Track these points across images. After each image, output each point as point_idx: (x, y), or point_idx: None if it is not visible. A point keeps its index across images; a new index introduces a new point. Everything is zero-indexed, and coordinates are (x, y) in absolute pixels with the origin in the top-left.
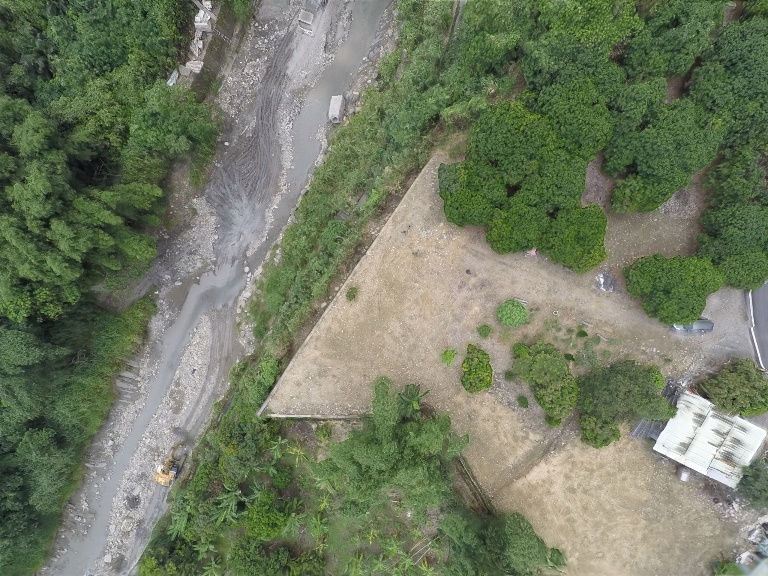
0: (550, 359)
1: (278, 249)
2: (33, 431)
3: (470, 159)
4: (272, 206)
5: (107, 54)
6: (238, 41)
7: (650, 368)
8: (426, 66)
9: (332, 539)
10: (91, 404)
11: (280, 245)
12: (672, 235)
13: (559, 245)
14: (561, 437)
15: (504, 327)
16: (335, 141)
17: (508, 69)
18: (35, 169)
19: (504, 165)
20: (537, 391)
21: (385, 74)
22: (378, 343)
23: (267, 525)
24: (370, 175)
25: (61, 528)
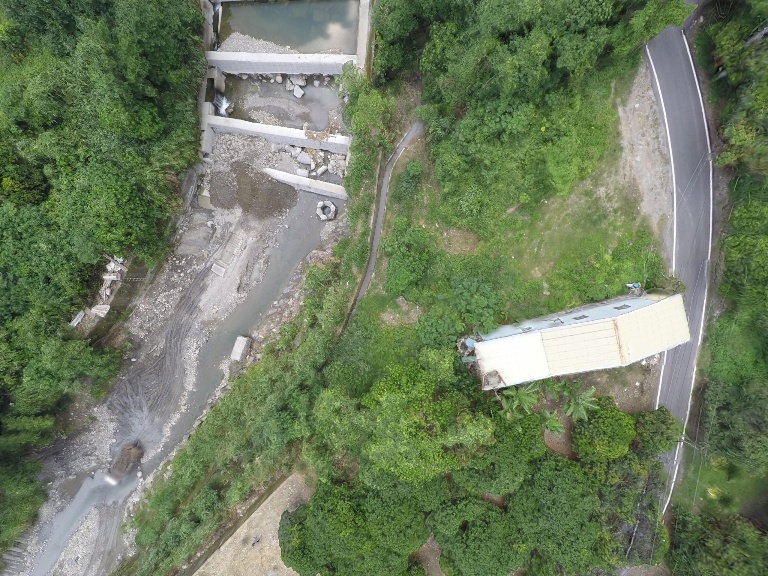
0: None
1: (169, 465)
2: None
3: None
4: (170, 423)
5: (8, 310)
6: (153, 275)
7: None
8: (311, 364)
9: None
10: None
11: (172, 461)
12: None
13: None
14: None
15: None
16: None
17: None
18: None
19: None
20: None
21: None
22: None
23: None
24: (250, 444)
25: None
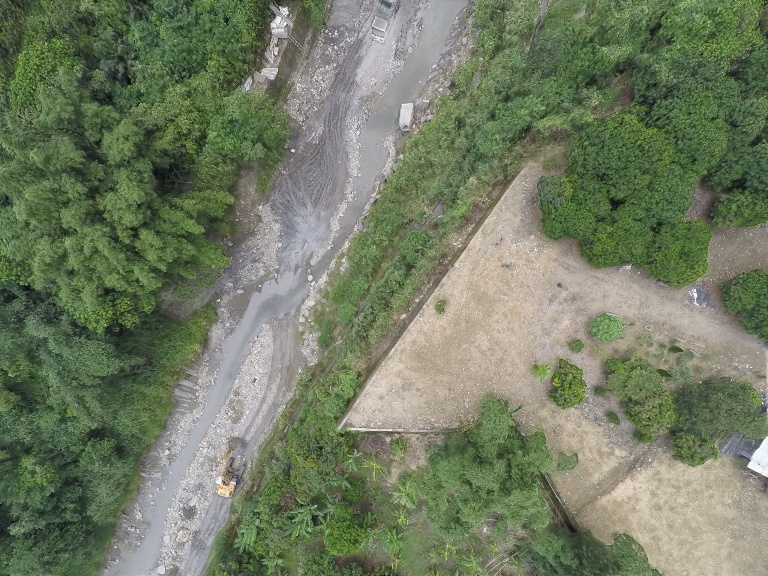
0: (646, 375)
1: (344, 258)
2: (95, 441)
3: (573, 172)
4: (338, 214)
5: (187, 60)
6: (309, 47)
7: (743, 385)
8: (510, 76)
9: (405, 554)
10: (151, 413)
11: (346, 254)
12: (767, 250)
13: (661, 260)
14: (648, 453)
15: (595, 342)
16: (406, 149)
17: (612, 81)
18: (124, 177)
19: (613, 179)
20: (631, 407)
21: (462, 83)
22: (464, 356)
23: (349, 541)
24: (448, 185)
25: (114, 538)
